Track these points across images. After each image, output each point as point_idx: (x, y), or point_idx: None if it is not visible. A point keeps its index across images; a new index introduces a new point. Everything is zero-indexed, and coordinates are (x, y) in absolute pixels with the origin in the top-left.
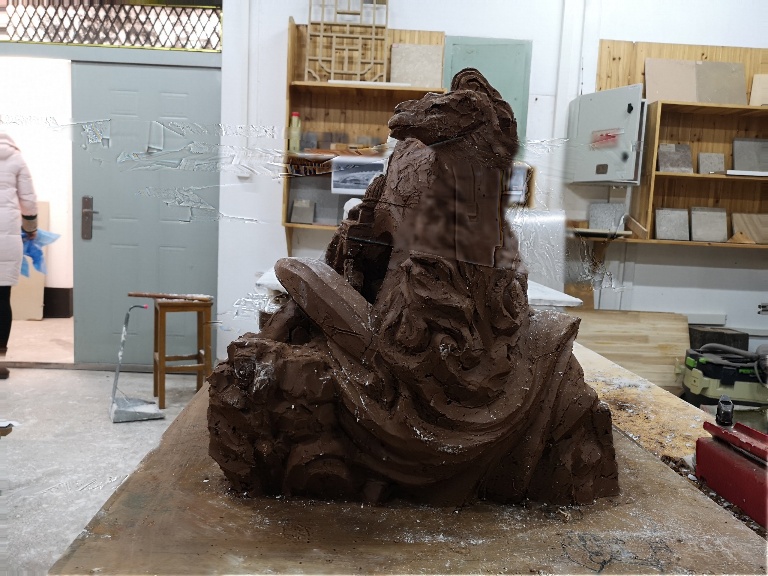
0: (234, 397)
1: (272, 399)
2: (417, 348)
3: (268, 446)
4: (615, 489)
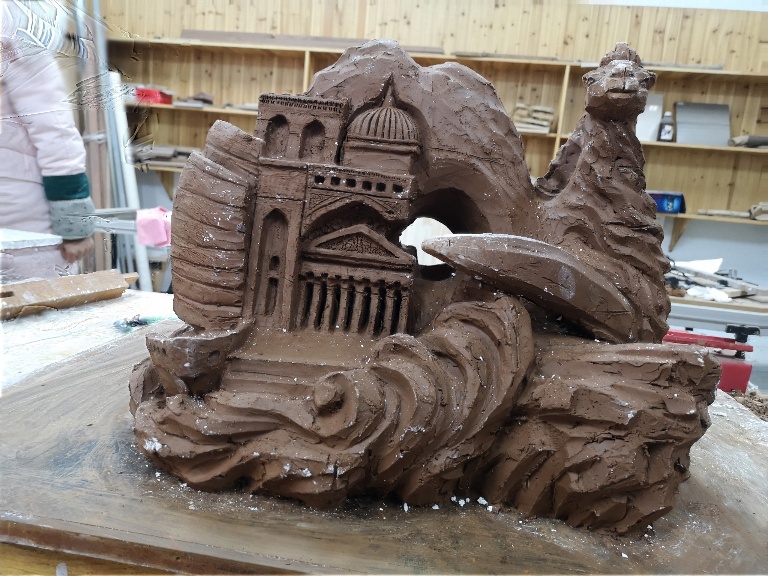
0: None
1: None
2: None
3: None
4: None
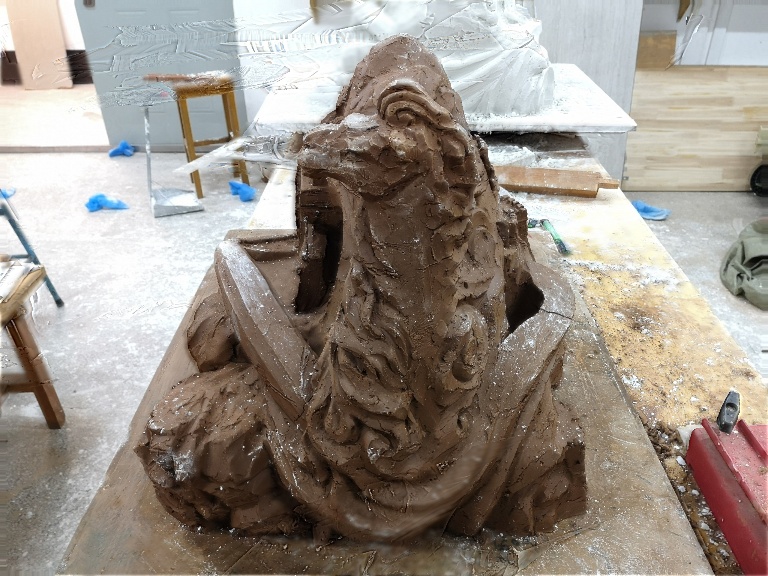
0: (160, 477)
1: (199, 480)
2: (346, 442)
3: (206, 511)
4: (582, 509)
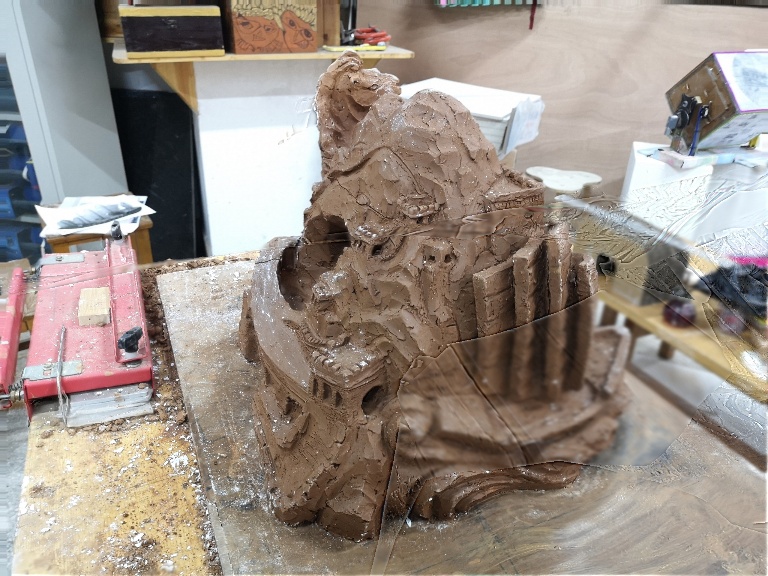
0: None
1: None
2: None
3: None
4: None
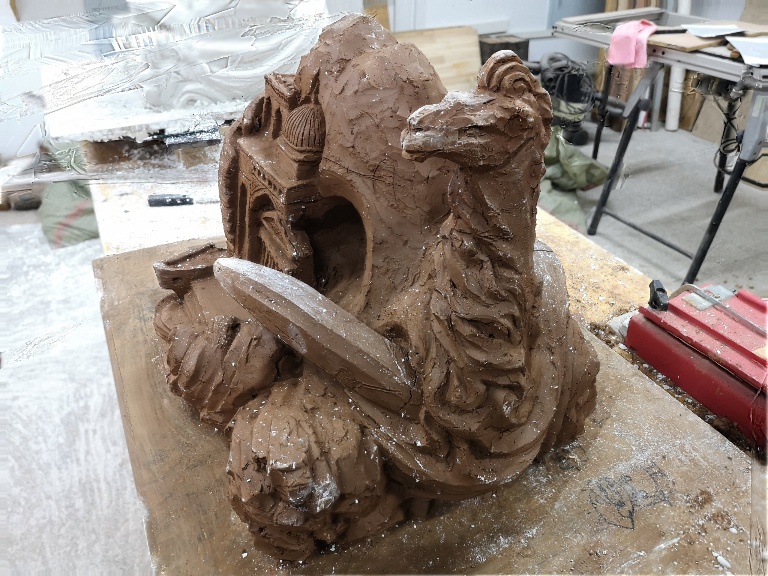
0: (291, 517)
1: None
2: (475, 408)
3: (331, 535)
4: (594, 406)
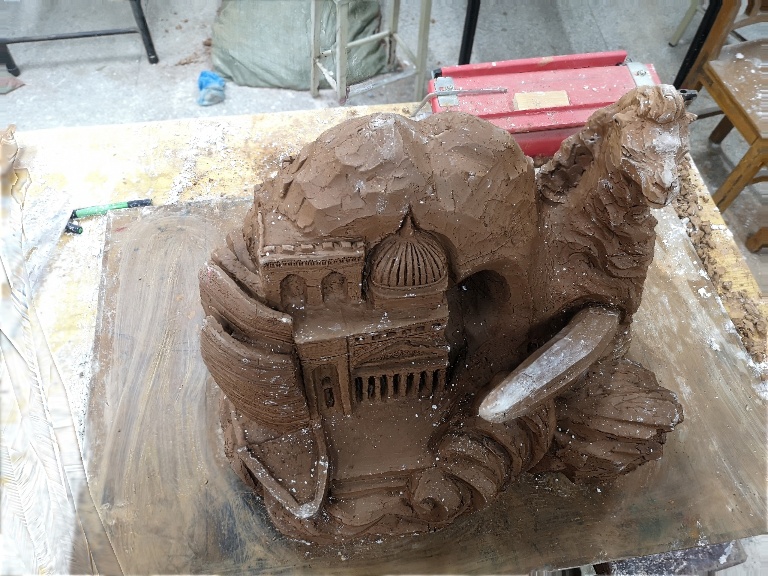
0: None
1: None
2: None
3: None
4: None
